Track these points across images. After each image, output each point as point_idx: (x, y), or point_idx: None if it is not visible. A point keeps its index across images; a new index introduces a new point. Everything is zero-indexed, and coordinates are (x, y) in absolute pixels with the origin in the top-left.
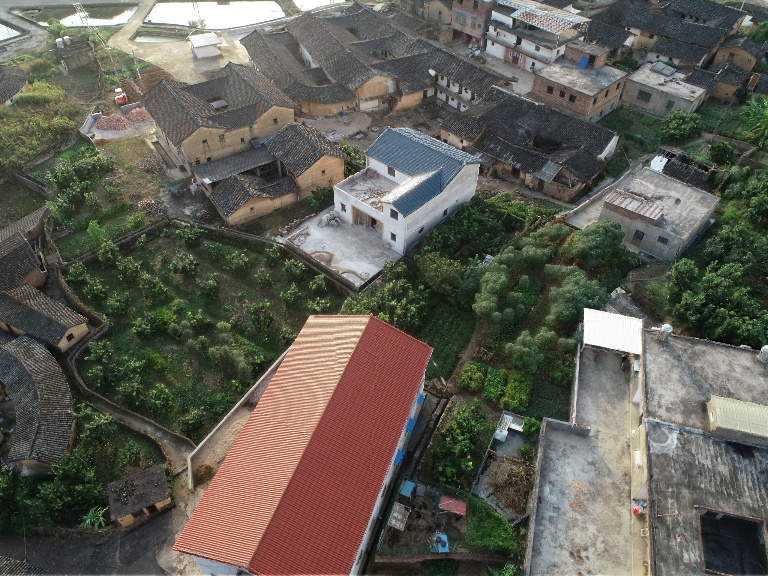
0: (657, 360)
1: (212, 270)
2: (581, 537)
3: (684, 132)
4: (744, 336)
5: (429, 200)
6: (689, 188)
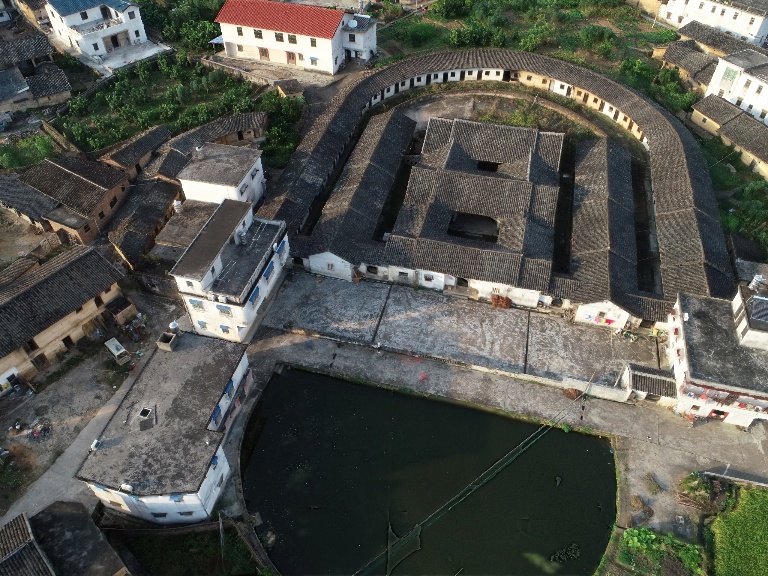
0: None
1: None
2: None
3: None
4: None
5: None
6: None
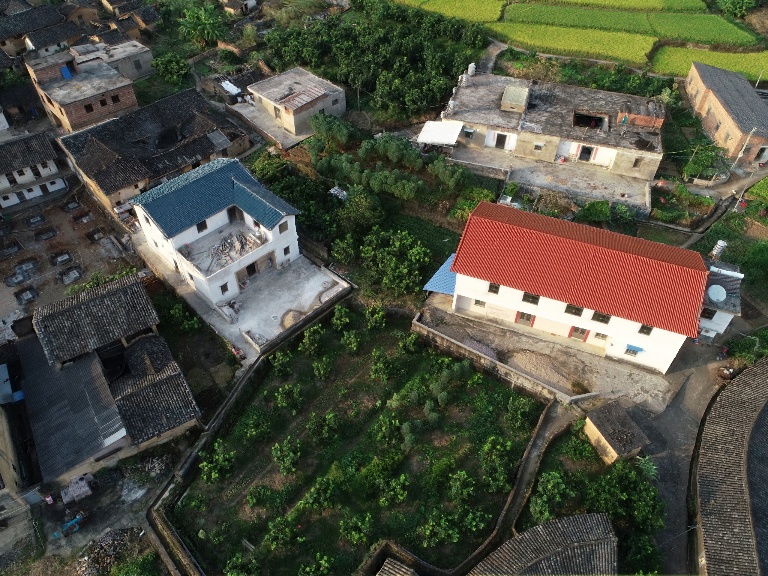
0: (470, 118)
1: (281, 440)
2: (582, 184)
3: (189, 67)
4: (442, 89)
5: (276, 196)
6: (282, 75)
